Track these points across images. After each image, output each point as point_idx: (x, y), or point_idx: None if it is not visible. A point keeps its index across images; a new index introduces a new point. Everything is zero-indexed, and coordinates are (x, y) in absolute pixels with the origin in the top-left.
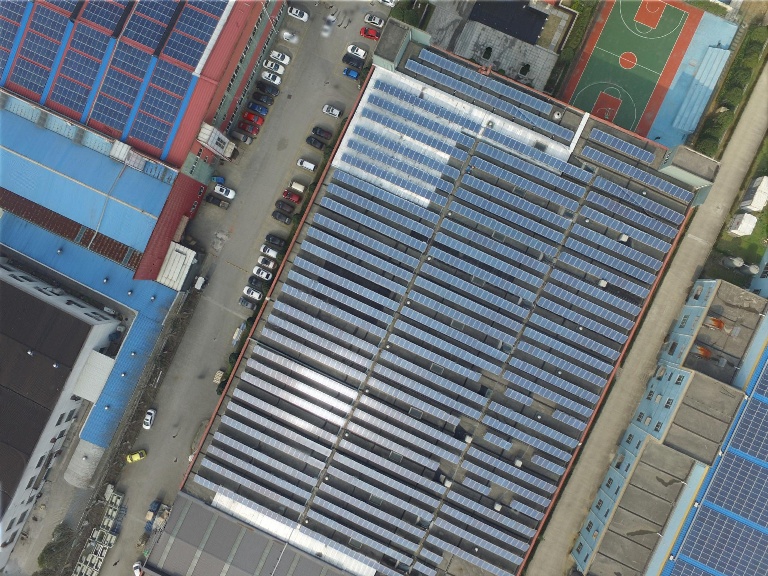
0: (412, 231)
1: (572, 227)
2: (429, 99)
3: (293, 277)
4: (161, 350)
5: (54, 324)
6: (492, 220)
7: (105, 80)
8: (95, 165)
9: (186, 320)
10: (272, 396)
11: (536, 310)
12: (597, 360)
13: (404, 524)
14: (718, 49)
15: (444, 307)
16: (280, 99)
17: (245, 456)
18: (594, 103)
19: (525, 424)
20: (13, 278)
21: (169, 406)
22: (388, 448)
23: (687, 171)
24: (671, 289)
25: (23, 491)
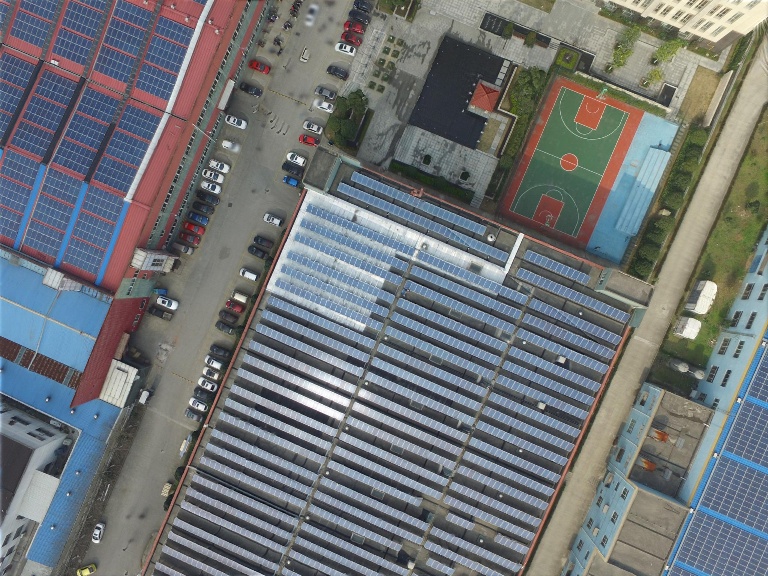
0: (349, 356)
1: (509, 349)
2: (362, 222)
3: (230, 405)
4: (107, 465)
5: None
6: (428, 344)
7: (37, 206)
8: (32, 286)
9: (132, 433)
10: (213, 524)
11: (476, 432)
12: (537, 483)
13: None
14: (659, 150)
15: (383, 432)
16: (221, 207)
17: None
18: (536, 206)
19: (467, 549)
20: None
21: (118, 519)
22: (330, 575)
23: (621, 295)
24: (619, 392)
25: None
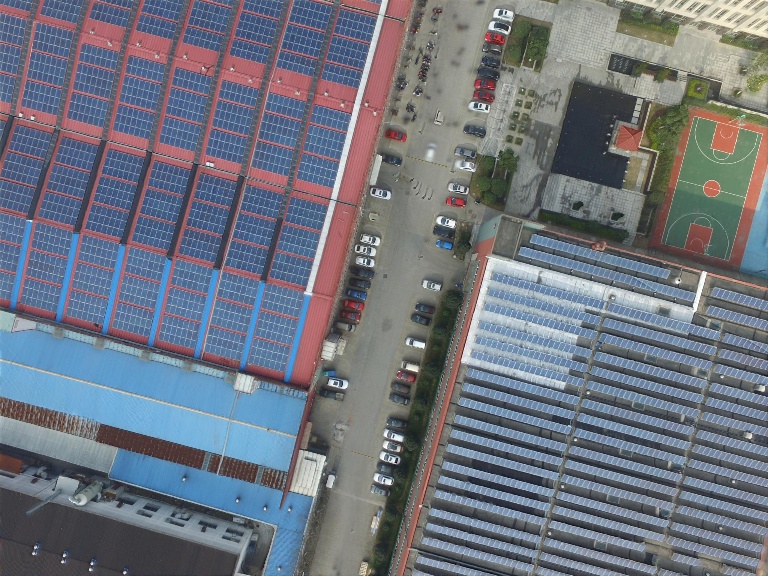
0: (554, 416)
1: (709, 386)
2: (547, 282)
3: (444, 482)
4: (302, 554)
5: (197, 559)
6: (631, 393)
7: (214, 312)
8: (210, 390)
9: (320, 518)
10: None
11: (687, 471)
12: (755, 511)
13: None
14: None
15: (599, 485)
16: (376, 280)
17: None
18: (686, 235)
19: None
20: (142, 516)
21: None
22: None
23: None
24: None
25: None
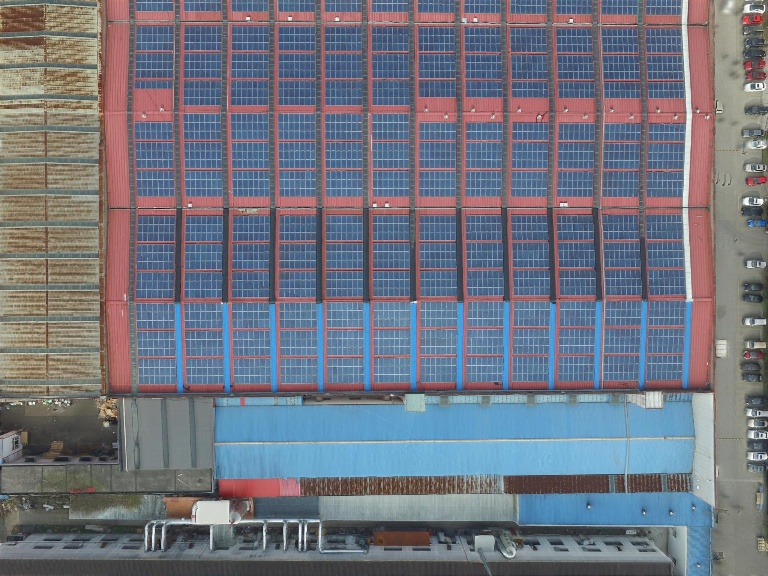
0: None
1: None
2: None
3: None
4: None
5: None
6: None
7: (605, 342)
8: (600, 416)
9: None
10: None
11: None
12: None
13: None
14: None
15: None
16: None
17: None
18: None
19: None
20: (561, 552)
21: None
22: None
23: None
24: None
25: None
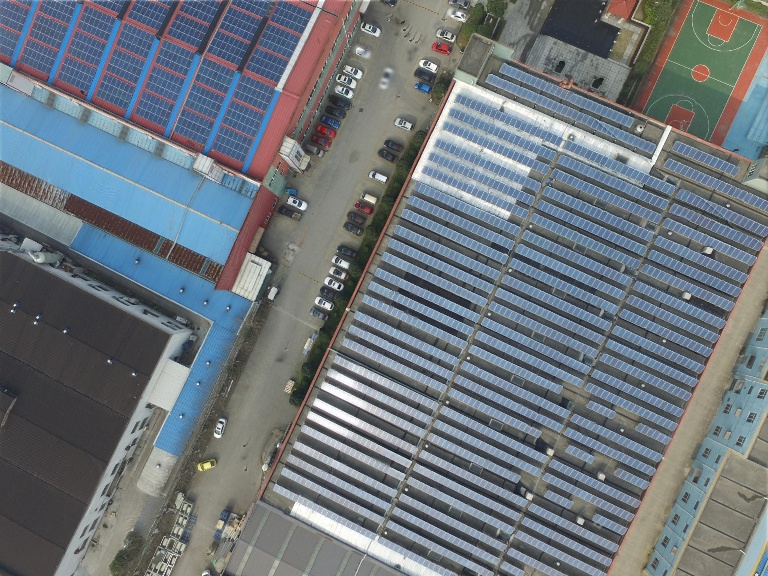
0: (493, 243)
1: (655, 239)
2: (509, 113)
3: (374, 288)
4: (234, 359)
5: (133, 333)
6: (574, 232)
7: (189, 95)
8: (175, 178)
9: (258, 330)
10: (352, 406)
11: (618, 322)
12: (681, 373)
13: (485, 537)
14: None
15: (525, 319)
16: (352, 112)
17: (324, 466)
18: (666, 115)
19: (608, 437)
20: (92, 288)
21: (240, 415)
22: (469, 460)
23: None
24: (746, 301)
25: (98, 498)
